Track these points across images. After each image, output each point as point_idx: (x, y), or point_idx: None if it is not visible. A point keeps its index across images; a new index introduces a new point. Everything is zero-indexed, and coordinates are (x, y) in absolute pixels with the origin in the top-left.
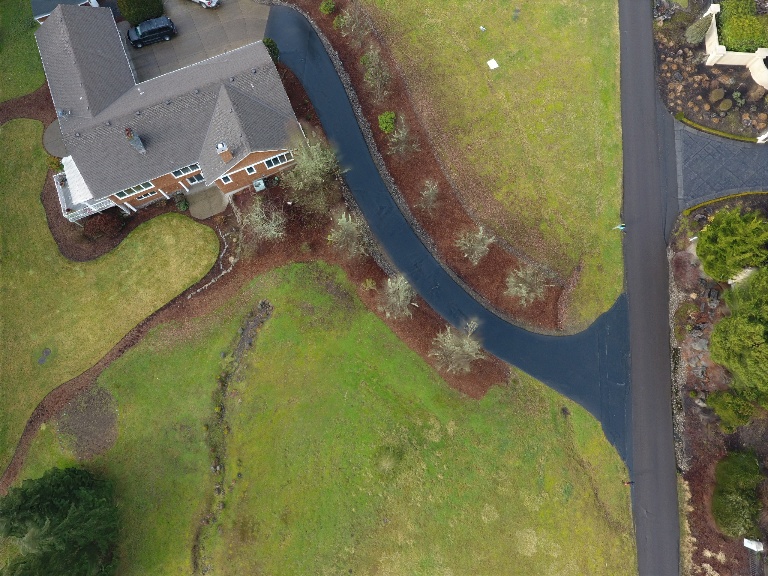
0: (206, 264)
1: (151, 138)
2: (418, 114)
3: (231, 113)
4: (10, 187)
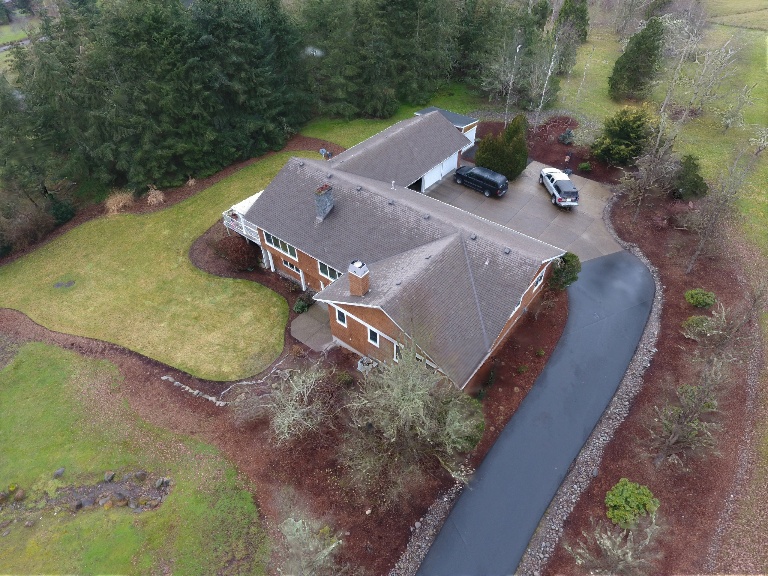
0: (224, 372)
1: (340, 215)
2: (710, 563)
3: (425, 259)
4: (250, 179)
